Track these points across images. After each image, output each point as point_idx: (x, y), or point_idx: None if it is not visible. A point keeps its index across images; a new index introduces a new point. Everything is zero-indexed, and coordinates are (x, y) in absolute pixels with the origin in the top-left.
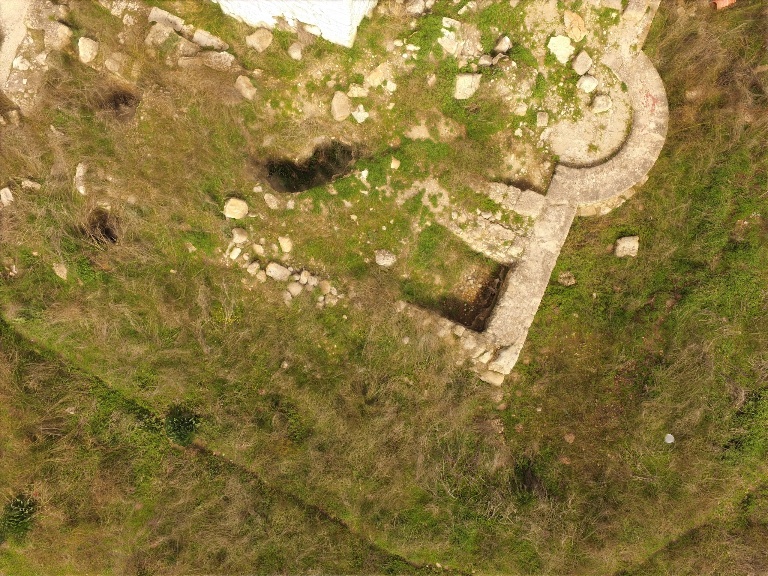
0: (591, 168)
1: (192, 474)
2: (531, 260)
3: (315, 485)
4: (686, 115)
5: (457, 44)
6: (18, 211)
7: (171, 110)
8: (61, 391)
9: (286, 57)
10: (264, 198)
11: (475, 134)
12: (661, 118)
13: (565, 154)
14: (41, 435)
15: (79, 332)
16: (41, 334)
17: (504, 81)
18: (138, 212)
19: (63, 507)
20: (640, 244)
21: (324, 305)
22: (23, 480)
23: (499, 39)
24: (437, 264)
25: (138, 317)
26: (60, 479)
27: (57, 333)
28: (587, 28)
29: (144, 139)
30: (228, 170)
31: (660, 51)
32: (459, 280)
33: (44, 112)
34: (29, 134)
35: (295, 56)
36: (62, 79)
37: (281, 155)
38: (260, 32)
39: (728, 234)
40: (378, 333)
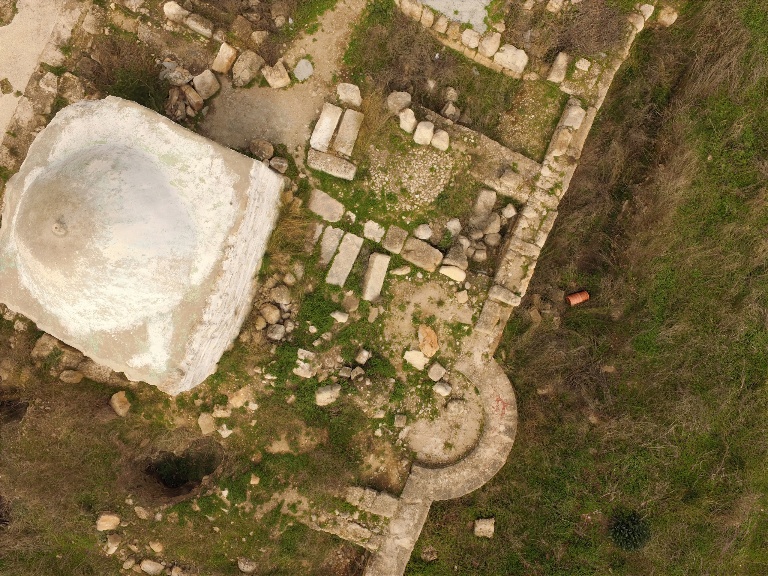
0: (444, 468)
1: None
2: (386, 556)
3: None
4: (536, 414)
5: (312, 371)
6: None
7: (50, 429)
8: None
9: None
10: (134, 510)
11: (336, 438)
12: (510, 421)
13: (422, 451)
14: None
15: None
16: None
17: (359, 397)
18: (23, 511)
19: None
20: (496, 526)
21: None
22: None
23: (360, 348)
24: (303, 551)
25: None
26: None
27: None
28: (441, 340)
29: (25, 455)
30: (101, 486)
31: (514, 351)
32: (328, 556)
33: None
34: None
35: None
36: None
37: None
38: None
39: (573, 527)
40: None
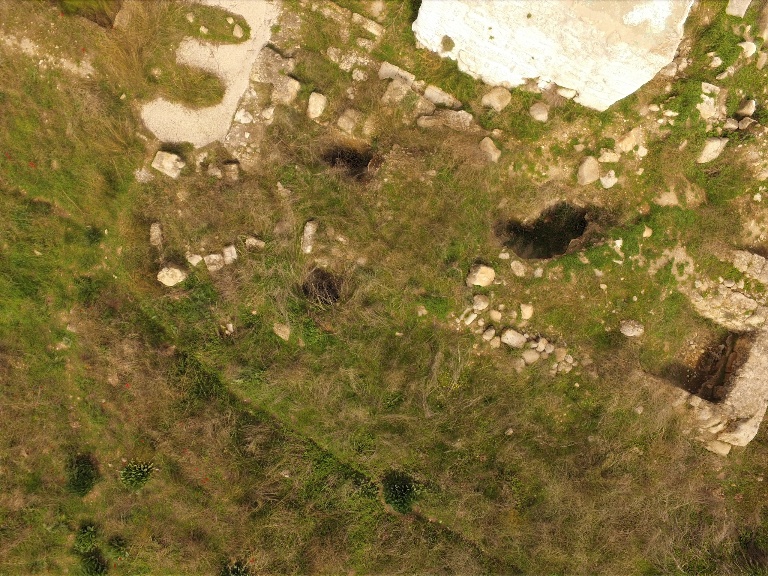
0: None
1: (410, 542)
2: None
3: (544, 558)
4: None
5: None
6: (247, 271)
7: (417, 173)
8: (278, 454)
9: (530, 118)
10: (511, 265)
11: (716, 199)
12: None
13: None
14: (262, 501)
15: (296, 393)
16: (257, 395)
17: (754, 147)
18: (372, 275)
19: (278, 574)
20: None
21: (556, 372)
22: (238, 546)
23: (741, 101)
24: (669, 331)
25: (359, 380)
26: (275, 545)
27: (274, 394)
28: None
29: (388, 202)
30: (476, 236)
31: None
32: (682, 345)
33: (272, 169)
34: (258, 191)
35: (540, 118)
36: (295, 136)
37: (510, 216)
38: (498, 91)
39: None
40: (622, 405)
